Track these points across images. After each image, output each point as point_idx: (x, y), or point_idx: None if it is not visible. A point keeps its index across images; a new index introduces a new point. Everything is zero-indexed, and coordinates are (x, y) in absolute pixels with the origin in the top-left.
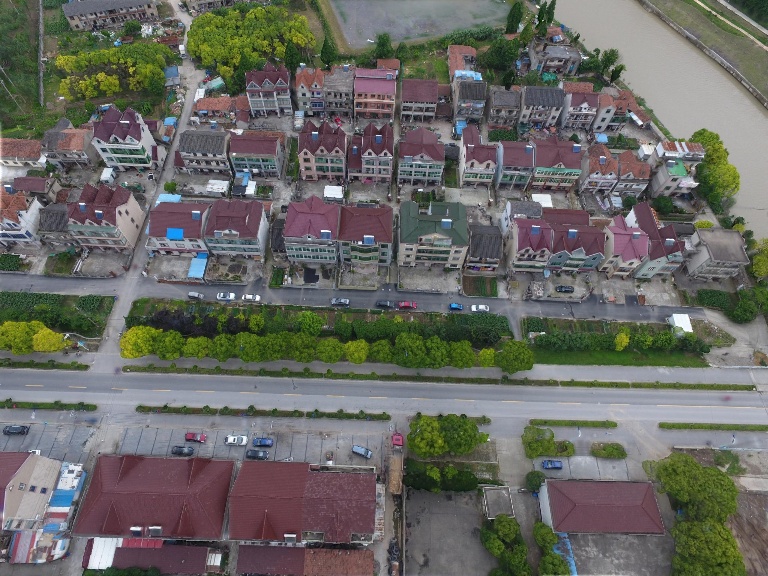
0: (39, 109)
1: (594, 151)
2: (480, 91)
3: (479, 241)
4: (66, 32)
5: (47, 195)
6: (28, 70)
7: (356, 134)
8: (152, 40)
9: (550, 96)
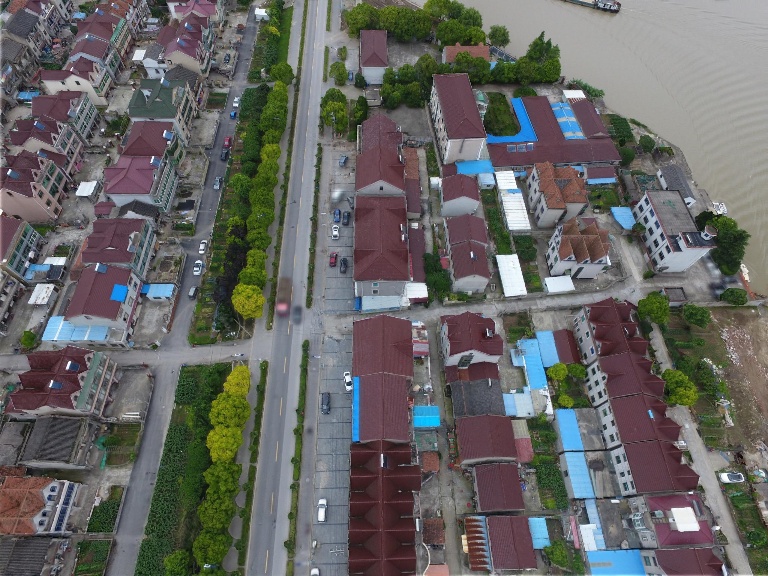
0: None
1: None
2: None
3: None
4: None
5: None
6: None
7: None
8: None
9: (23, 20)
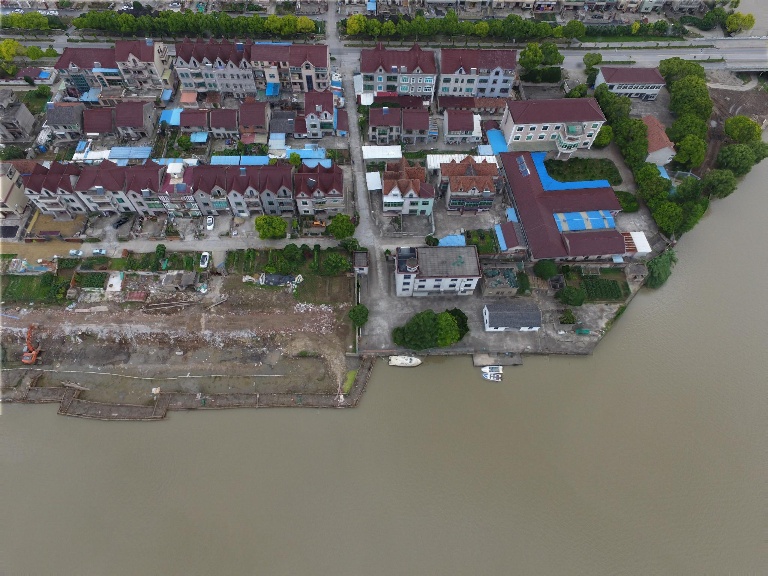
0: None
1: None
2: None
3: None
4: None
5: None
6: None
7: None
8: None
9: None
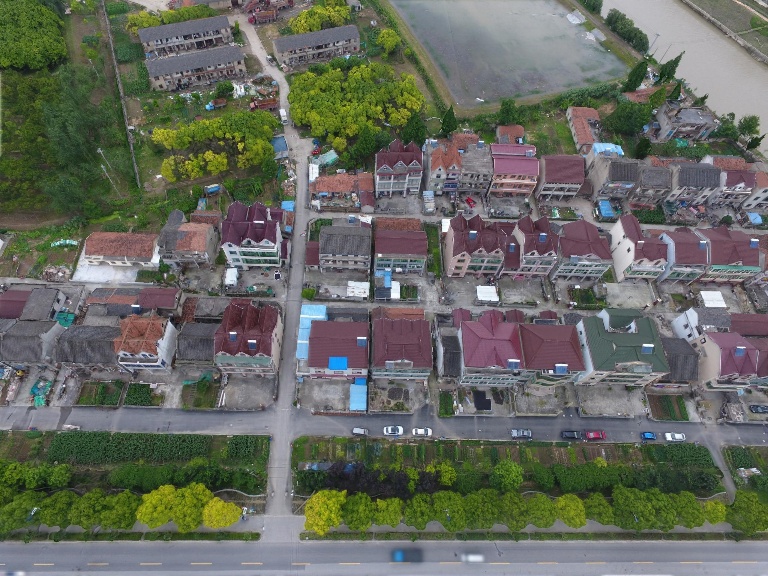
0: (136, 191)
1: (764, 242)
2: (631, 171)
3: (673, 361)
4: (148, 93)
5: (175, 310)
6: (115, 142)
7: (492, 217)
8: (245, 102)
9: (705, 176)
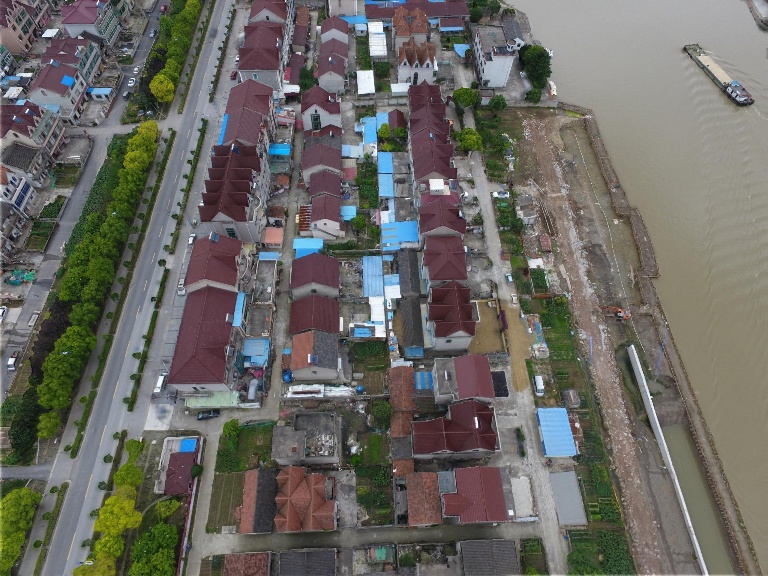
0: None
1: None
2: None
3: None
4: None
5: None
6: None
7: None
8: None
9: None
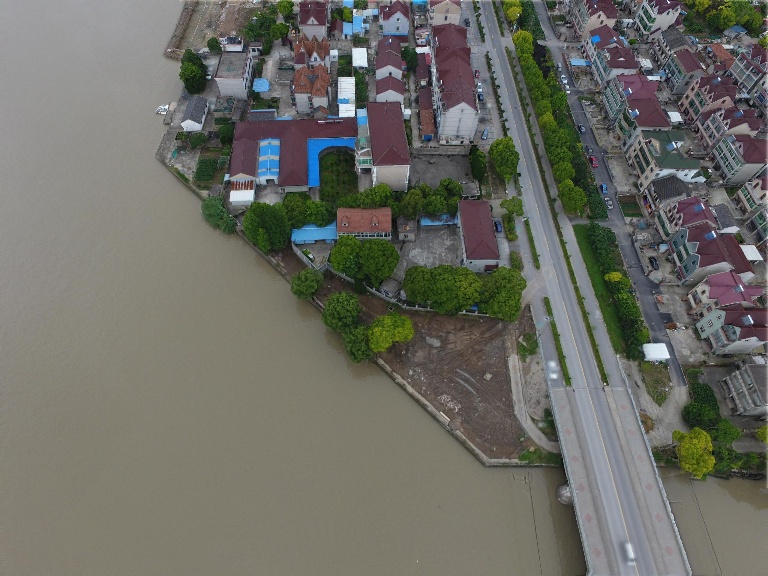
0: None
1: None
2: None
3: (669, 183)
4: None
5: None
6: None
7: None
8: None
9: None
